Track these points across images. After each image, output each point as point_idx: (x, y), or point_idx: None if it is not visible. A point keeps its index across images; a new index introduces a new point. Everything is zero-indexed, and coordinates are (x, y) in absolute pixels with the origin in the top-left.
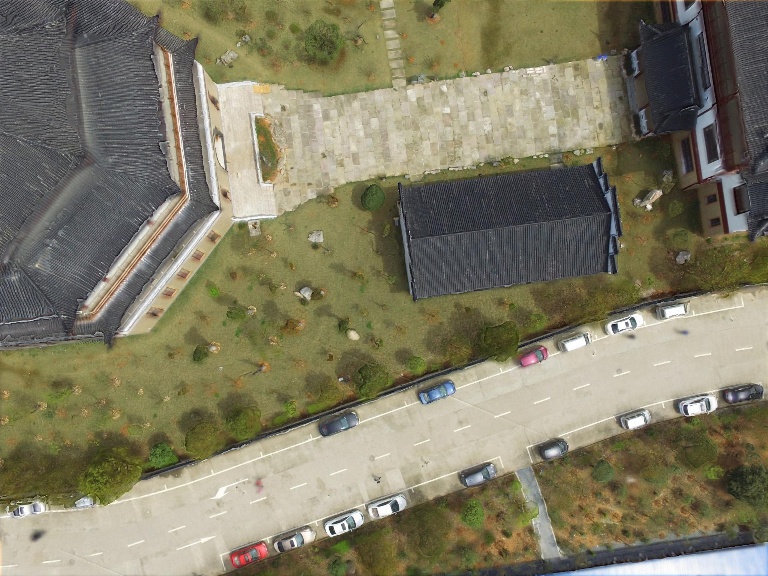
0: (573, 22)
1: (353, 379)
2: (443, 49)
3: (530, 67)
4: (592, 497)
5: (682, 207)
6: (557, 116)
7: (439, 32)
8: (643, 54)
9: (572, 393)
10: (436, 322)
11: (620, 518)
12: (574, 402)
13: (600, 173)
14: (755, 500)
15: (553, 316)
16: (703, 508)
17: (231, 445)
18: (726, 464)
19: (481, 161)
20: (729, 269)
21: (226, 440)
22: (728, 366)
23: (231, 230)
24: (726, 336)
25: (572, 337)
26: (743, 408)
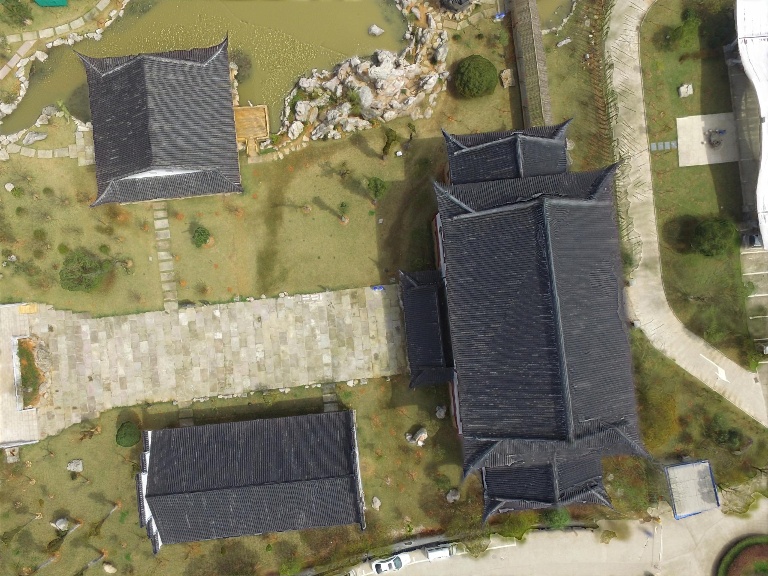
0: (351, 249)
1: None
2: (217, 273)
3: (306, 293)
4: None
5: (444, 454)
6: (332, 345)
7: (213, 256)
8: (404, 301)
9: None
10: (198, 555)
11: None
12: None
13: (351, 427)
14: None
15: (319, 551)
16: None
17: None
18: None
19: (252, 389)
20: (473, 535)
21: None
22: None
23: None
24: (496, 575)
25: (335, 575)
26: None
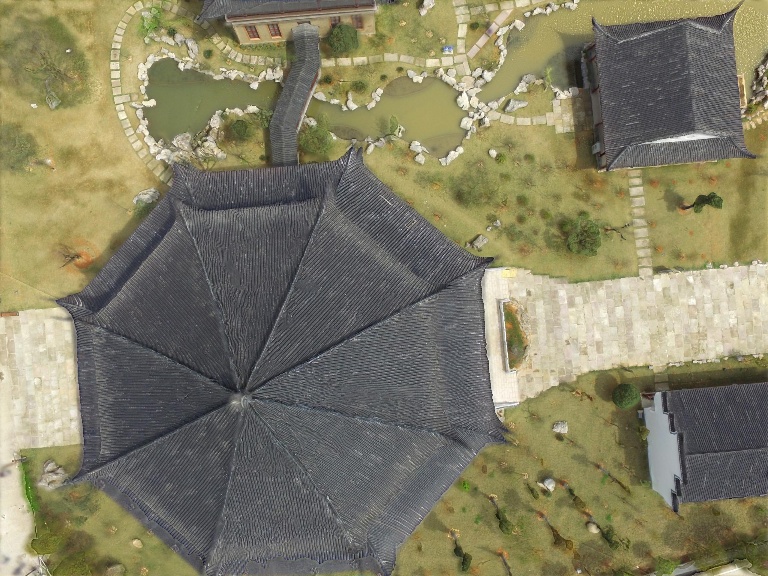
0: None
1: (589, 570)
2: (692, 240)
3: None
4: None
5: None
6: None
7: (689, 223)
8: None
9: None
10: (675, 517)
11: None
12: None
13: None
14: None
15: None
16: None
17: None
18: None
19: (725, 355)
20: None
21: None
22: None
23: None
24: None
25: None
26: None
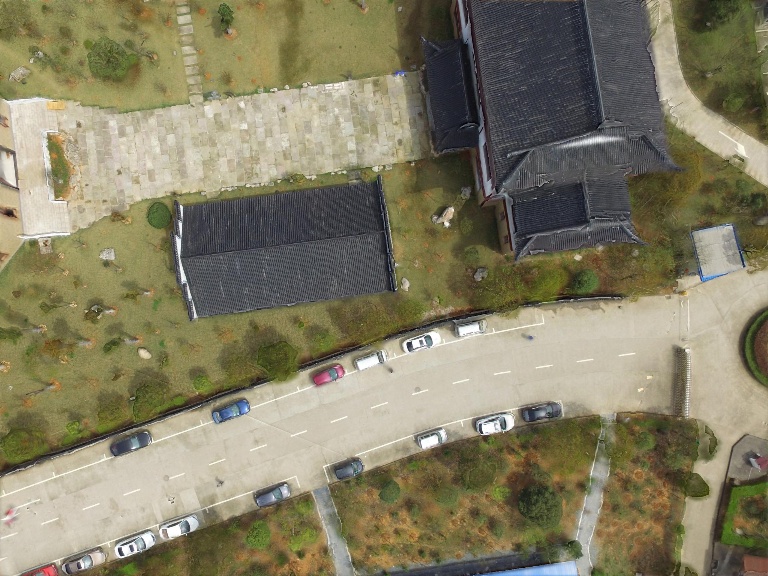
0: (372, 38)
1: None
2: (240, 65)
3: (329, 83)
4: (389, 517)
5: (471, 224)
6: (356, 132)
7: (236, 48)
8: (427, 71)
9: (369, 412)
10: (231, 340)
11: (416, 538)
12: (371, 421)
13: (379, 191)
14: (539, 521)
15: (350, 334)
16: (498, 528)
17: (15, 466)
18: (524, 483)
19: (278, 177)
20: (504, 288)
21: (5, 461)
22: (527, 384)
23: (23, 248)
24: (526, 354)
25: (367, 355)
26: (542, 426)
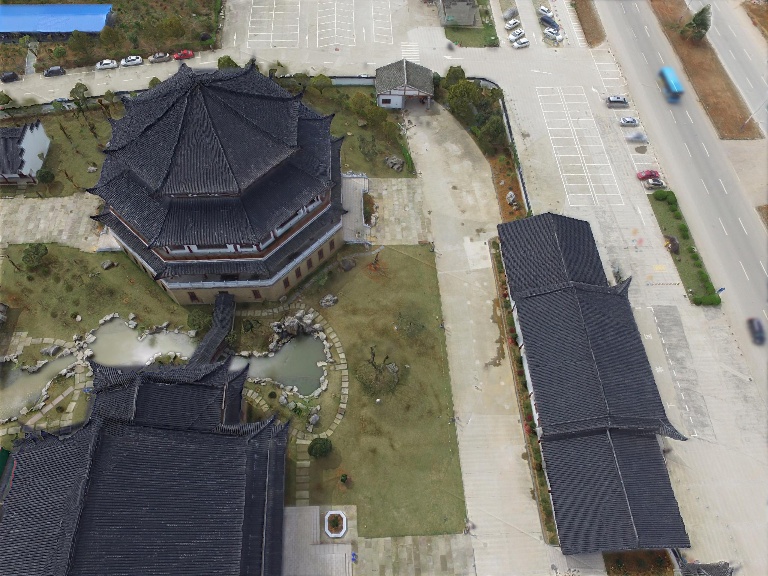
0: None
1: None
2: None
3: None
4: (1, 61)
5: None
6: None
7: None
8: None
9: None
10: None
11: None
12: None
13: None
14: None
15: None
16: None
17: None
18: None
19: None
20: None
21: None
22: None
23: None
24: None
25: None
26: None
